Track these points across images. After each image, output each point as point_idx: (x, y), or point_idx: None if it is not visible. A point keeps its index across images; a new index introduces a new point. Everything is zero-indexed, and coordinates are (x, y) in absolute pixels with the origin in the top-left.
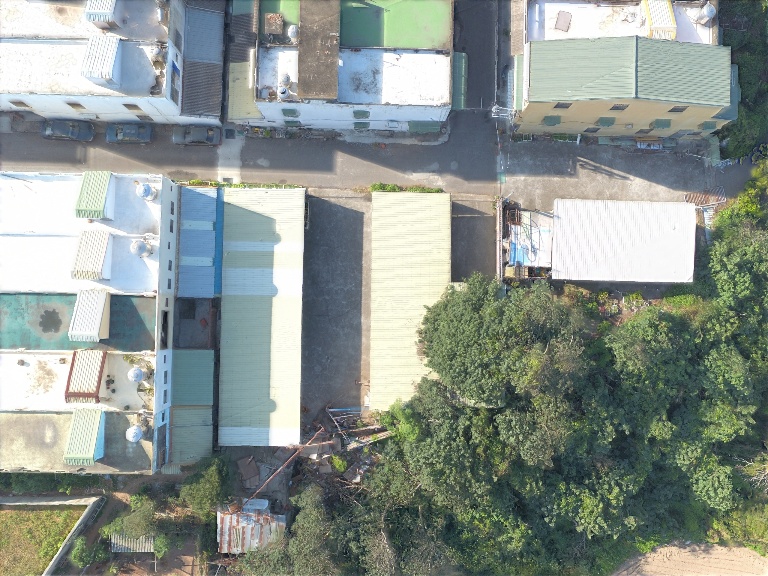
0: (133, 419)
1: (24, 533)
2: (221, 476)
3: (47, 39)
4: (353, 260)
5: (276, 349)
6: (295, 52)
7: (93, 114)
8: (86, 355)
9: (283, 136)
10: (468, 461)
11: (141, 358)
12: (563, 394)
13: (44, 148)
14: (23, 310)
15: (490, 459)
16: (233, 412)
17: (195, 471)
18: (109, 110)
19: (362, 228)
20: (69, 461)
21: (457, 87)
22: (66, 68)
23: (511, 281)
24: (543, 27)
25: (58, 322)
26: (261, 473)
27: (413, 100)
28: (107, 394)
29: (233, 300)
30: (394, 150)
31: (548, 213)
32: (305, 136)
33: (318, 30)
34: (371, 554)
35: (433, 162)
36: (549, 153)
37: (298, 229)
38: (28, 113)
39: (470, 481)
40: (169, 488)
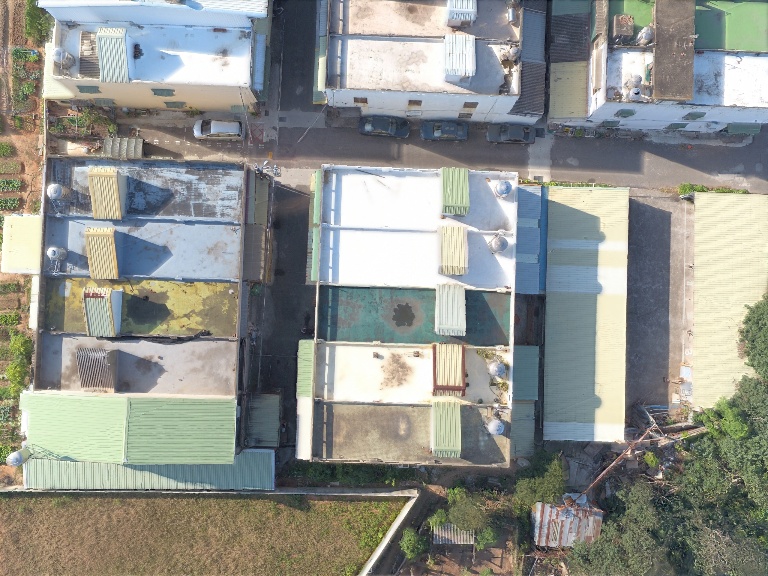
0: (486, 412)
1: (343, 523)
2: None
3: (400, 36)
4: (661, 259)
5: (600, 346)
6: (639, 53)
7: (419, 111)
8: (446, 349)
9: (593, 135)
10: None
11: (493, 352)
12: None
13: (358, 144)
14: (377, 303)
15: None
16: (558, 407)
17: None
18: (441, 107)
19: (669, 227)
20: (437, 453)
21: None
22: (417, 65)
23: None
24: None
25: (411, 316)
26: (570, 468)
27: (754, 102)
28: None
29: (557, 297)
30: (700, 151)
31: None
32: (614, 136)
33: (674, 32)
34: (708, 549)
35: (738, 163)
36: None
37: (622, 228)
38: (352, 109)
39: None
40: (483, 481)
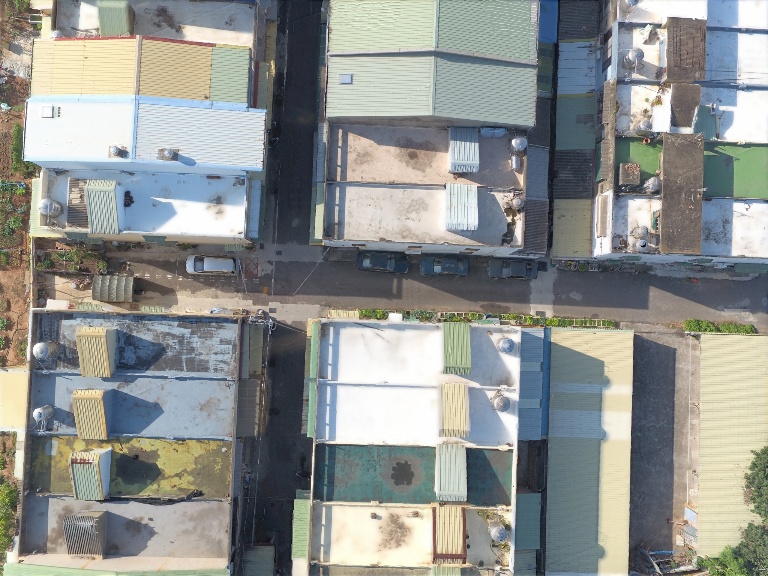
0: (487, 575)
1: None
2: None
3: (400, 184)
4: (665, 397)
5: (604, 493)
6: (645, 200)
7: (419, 250)
8: (446, 512)
9: (596, 270)
10: None
11: (494, 512)
12: None
13: (356, 278)
14: (375, 462)
15: None
16: (560, 557)
17: None
18: (442, 249)
19: (674, 364)
20: None
21: None
22: (417, 213)
23: None
24: None
25: (410, 474)
26: None
27: (763, 251)
28: None
29: (560, 442)
30: (705, 285)
31: None
32: (618, 270)
33: (681, 184)
34: None
35: (744, 298)
36: None
37: (627, 372)
38: None
39: None
40: None
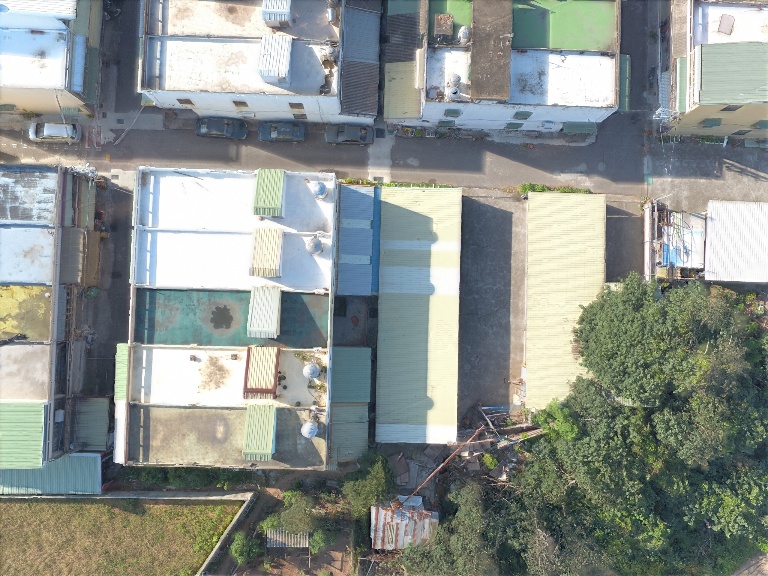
0: (304, 415)
1: (178, 527)
2: (385, 472)
3: (219, 37)
4: (502, 259)
5: (433, 347)
6: (462, 52)
7: (251, 112)
8: (260, 351)
9: (433, 136)
10: (626, 460)
11: (311, 355)
12: (726, 394)
13: (196, 145)
14: (194, 306)
15: (643, 458)
16: (390, 409)
17: (345, 467)
18: (270, 108)
19: (511, 228)
20: (247, 456)
21: (622, 89)
22: (236, 66)
23: (661, 282)
24: (706, 30)
25: (229, 318)
26: (411, 470)
27: (578, 101)
28: (278, 390)
29: (390, 298)
30: (542, 150)
31: (700, 214)
32: (455, 136)
33: (491, 31)
34: (534, 551)
35: (581, 163)
36: (695, 155)
37: (455, 228)
38: (185, 110)
39: (623, 479)
40: (321, 484)
